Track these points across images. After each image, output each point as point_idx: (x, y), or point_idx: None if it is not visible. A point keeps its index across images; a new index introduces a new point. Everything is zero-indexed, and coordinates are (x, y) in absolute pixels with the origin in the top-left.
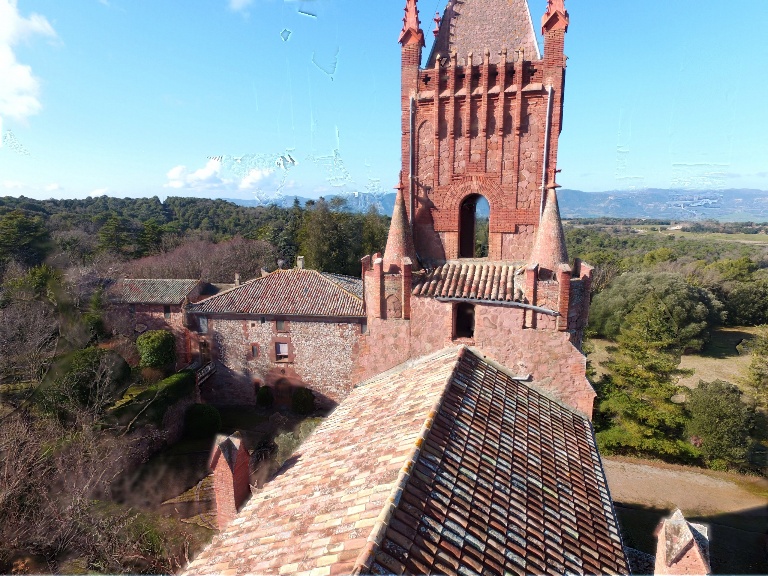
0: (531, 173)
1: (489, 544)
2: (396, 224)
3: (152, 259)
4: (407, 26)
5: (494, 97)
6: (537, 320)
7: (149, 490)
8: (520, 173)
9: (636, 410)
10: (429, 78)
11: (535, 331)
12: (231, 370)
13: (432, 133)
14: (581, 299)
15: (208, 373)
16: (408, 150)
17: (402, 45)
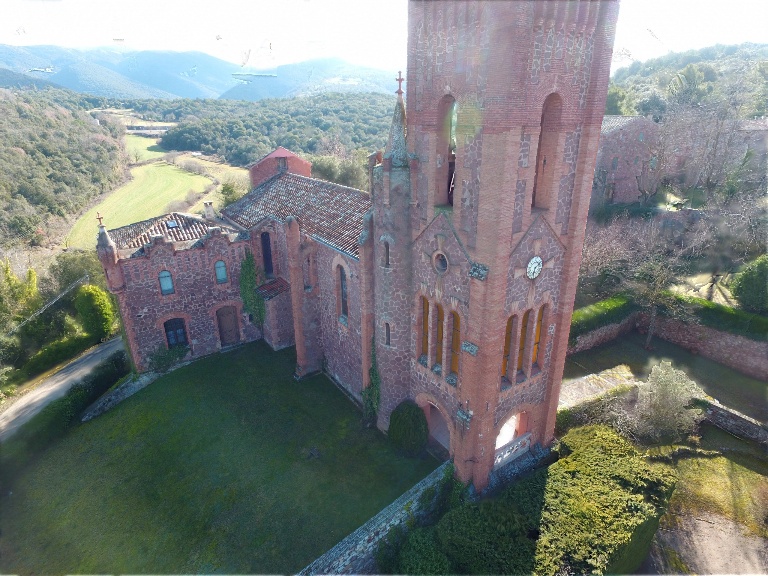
0: None
1: None
2: None
3: None
4: None
5: None
6: None
7: (688, 367)
8: None
9: None
10: None
11: None
12: None
13: None
14: None
15: None
16: None
17: None
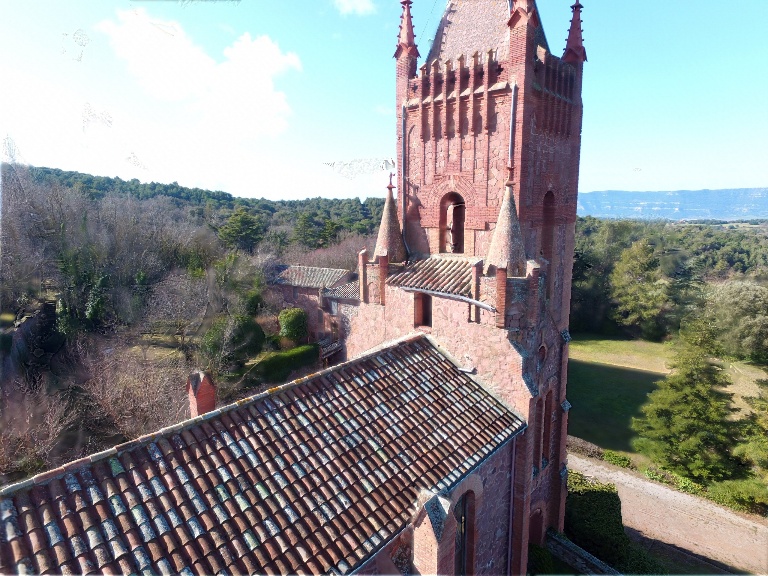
0: (499, 171)
1: (266, 465)
2: (383, 220)
3: (322, 251)
4: (401, 42)
5: (466, 99)
6: (480, 315)
7: None
8: (490, 171)
9: None
10: (417, 86)
11: (478, 325)
12: None
13: (419, 137)
14: (524, 298)
15: (334, 350)
16: (401, 153)
17: None
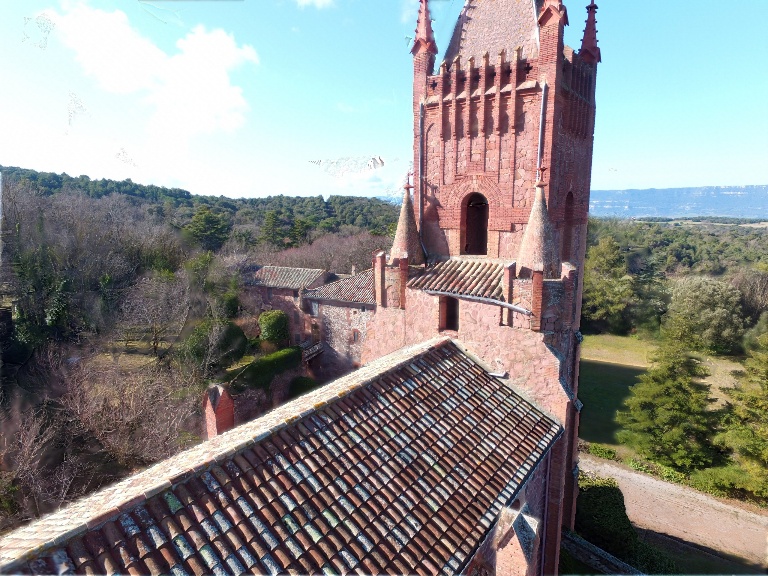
0: (527, 171)
1: (328, 489)
2: (401, 221)
3: (294, 250)
4: (418, 37)
5: (491, 97)
6: (513, 318)
7: None
8: (516, 172)
9: (761, 449)
10: (436, 83)
11: (511, 329)
12: (336, 351)
13: (438, 135)
14: (560, 300)
15: (316, 352)
16: (418, 152)
17: (414, 55)
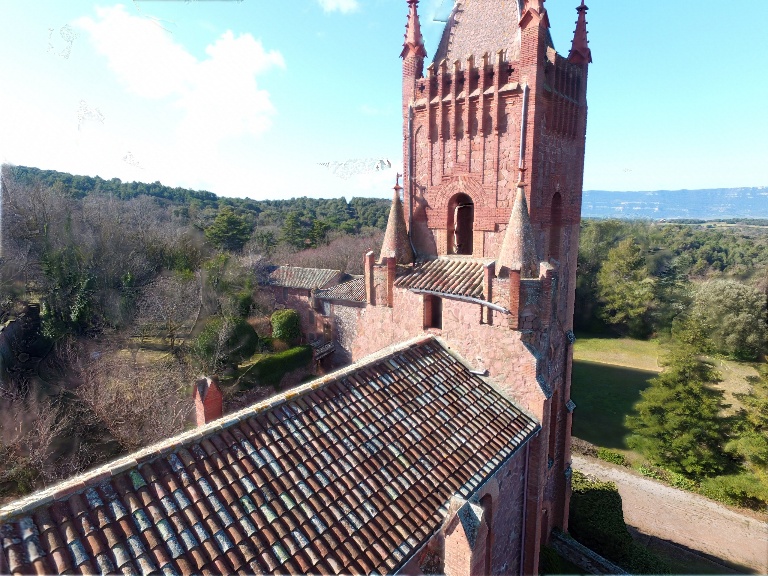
0: (509, 172)
1: (289, 474)
2: (390, 221)
3: (311, 251)
4: (407, 41)
5: (475, 100)
6: (493, 317)
7: None
8: (500, 172)
9: None
10: (424, 86)
11: (490, 327)
12: (347, 351)
13: (426, 137)
14: (538, 299)
15: (327, 351)
16: (408, 154)
17: (403, 59)
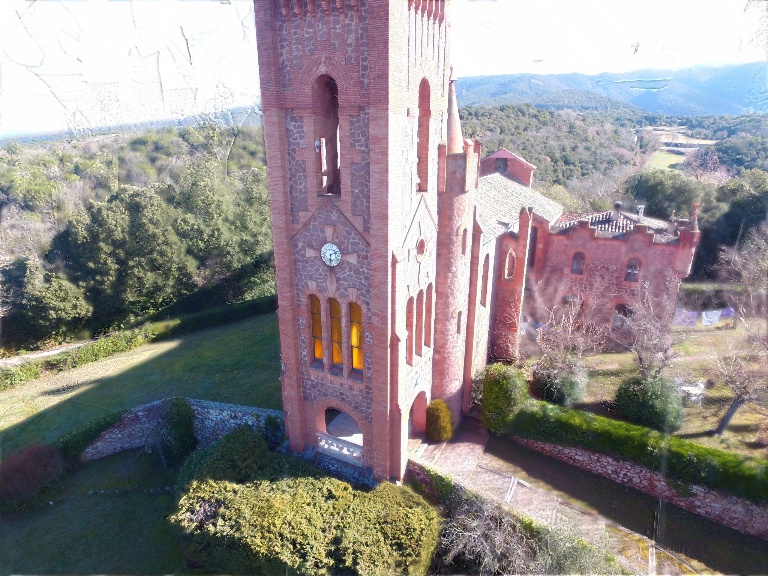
0: None
1: None
2: None
3: None
4: None
5: None
6: None
7: None
8: None
9: None
10: None
11: None
12: None
13: None
14: None
15: None
16: None
17: None
